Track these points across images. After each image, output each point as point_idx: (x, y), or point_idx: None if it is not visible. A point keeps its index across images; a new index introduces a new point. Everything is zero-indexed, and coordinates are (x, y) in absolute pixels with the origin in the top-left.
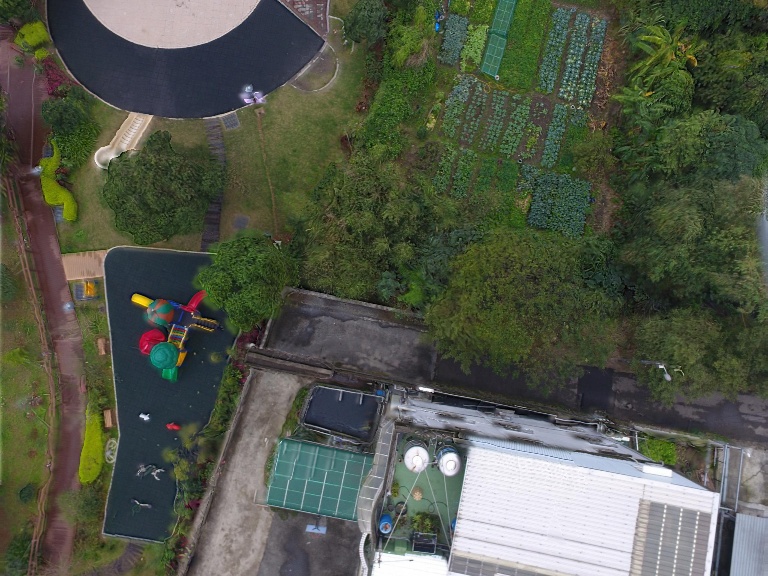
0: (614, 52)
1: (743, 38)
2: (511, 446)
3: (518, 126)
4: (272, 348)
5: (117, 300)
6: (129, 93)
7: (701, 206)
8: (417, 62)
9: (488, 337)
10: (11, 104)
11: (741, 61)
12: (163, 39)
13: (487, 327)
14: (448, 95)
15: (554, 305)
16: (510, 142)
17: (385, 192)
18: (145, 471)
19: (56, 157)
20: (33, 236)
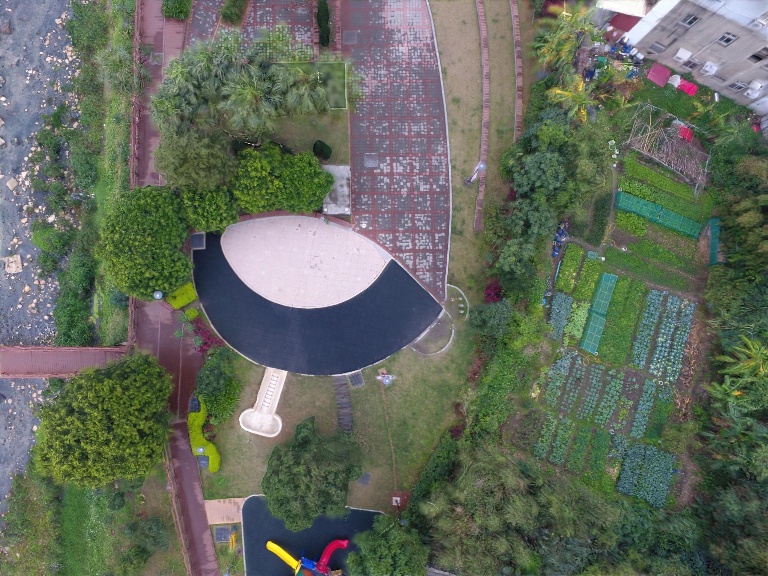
0: (700, 332)
1: None
2: None
3: (612, 399)
4: None
5: (253, 545)
6: (266, 349)
7: None
8: (532, 353)
9: None
10: (161, 357)
11: None
12: (297, 299)
13: None
14: (551, 366)
15: None
16: (604, 414)
17: (506, 491)
18: None
19: (203, 413)
20: (179, 482)
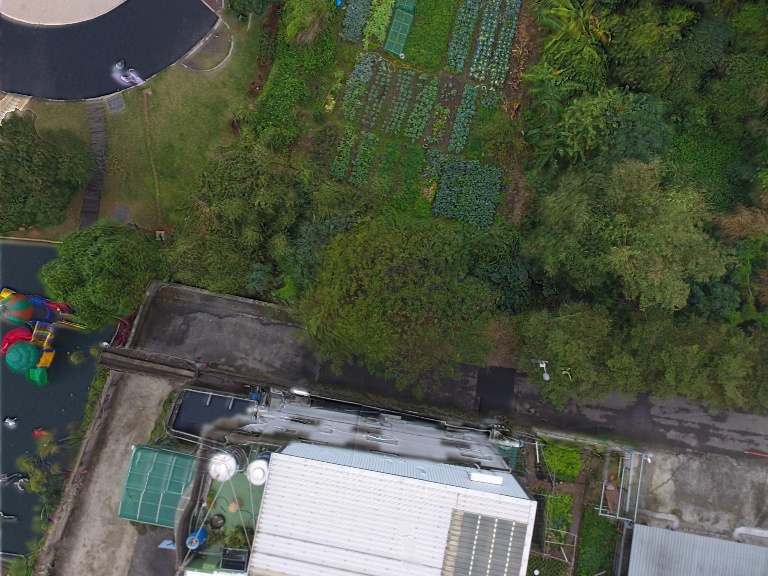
0: (530, 29)
1: (660, 10)
2: (345, 462)
3: (424, 108)
4: (142, 347)
5: None
6: (7, 73)
7: (601, 191)
8: (308, 37)
9: (353, 336)
10: None
11: (656, 35)
12: (45, 15)
13: (351, 325)
14: (350, 75)
15: (423, 300)
16: (415, 126)
17: (261, 177)
18: (6, 481)
19: None
20: None
